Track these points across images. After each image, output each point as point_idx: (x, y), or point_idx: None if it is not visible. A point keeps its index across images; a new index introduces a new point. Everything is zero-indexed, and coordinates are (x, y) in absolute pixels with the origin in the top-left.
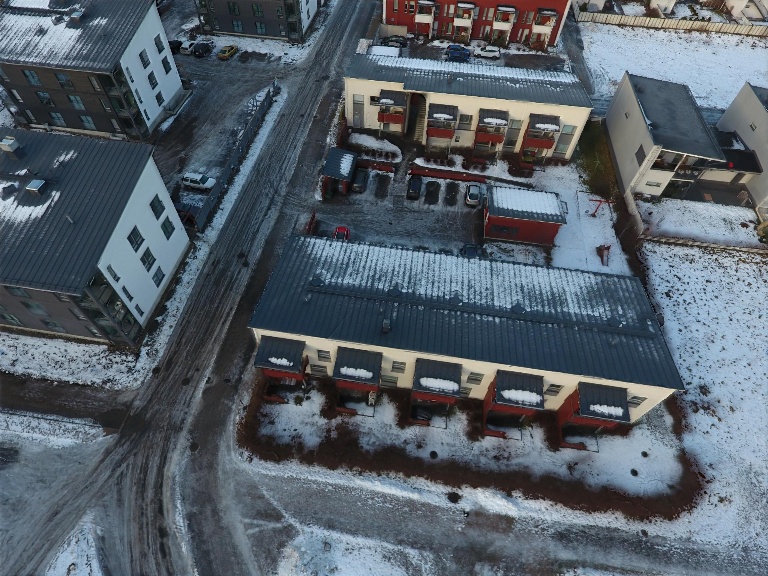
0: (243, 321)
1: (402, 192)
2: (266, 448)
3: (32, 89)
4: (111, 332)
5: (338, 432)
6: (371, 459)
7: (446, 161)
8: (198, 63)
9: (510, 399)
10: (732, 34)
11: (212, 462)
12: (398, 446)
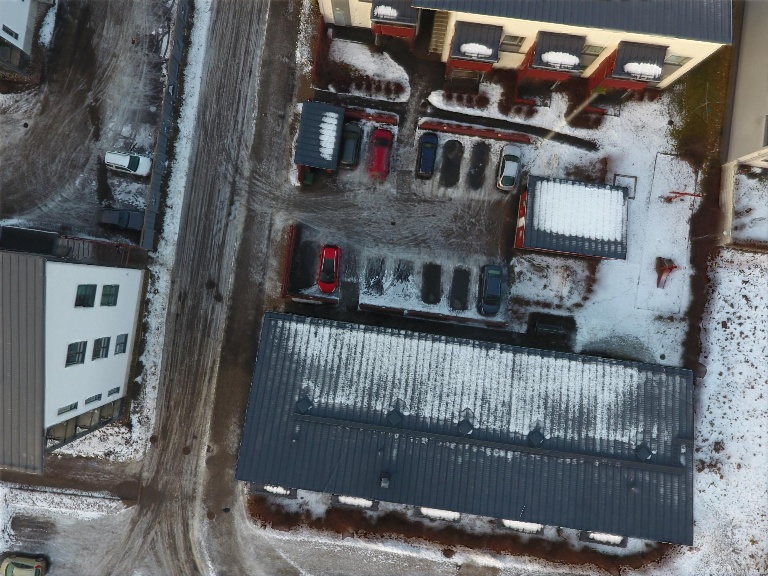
0: (230, 379)
1: (409, 164)
2: (277, 517)
3: None
4: None
5: None
6: (375, 524)
7: (475, 98)
8: None
9: (511, 528)
10: None
11: (230, 529)
12: (400, 511)
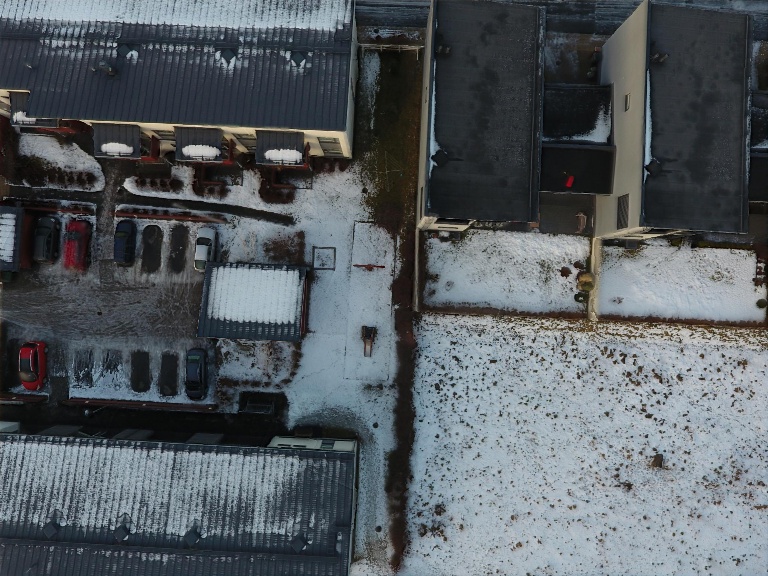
0: None
1: (110, 253)
2: None
3: None
4: None
5: None
6: None
7: (168, 182)
8: None
9: None
10: None
11: None
12: None
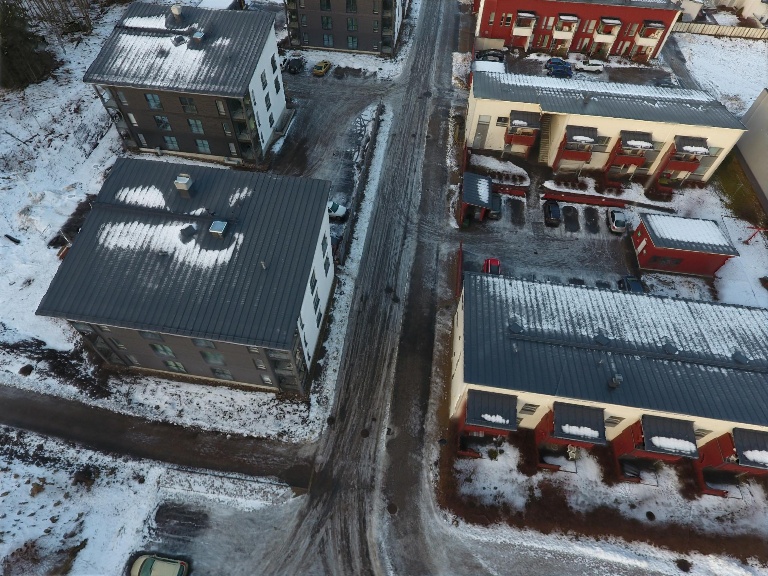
0: (409, 364)
1: (539, 218)
2: (471, 510)
3: (151, 113)
4: (281, 379)
5: (542, 490)
6: (585, 521)
7: (577, 184)
8: (294, 80)
9: (756, 461)
10: None
11: (416, 526)
12: (610, 506)
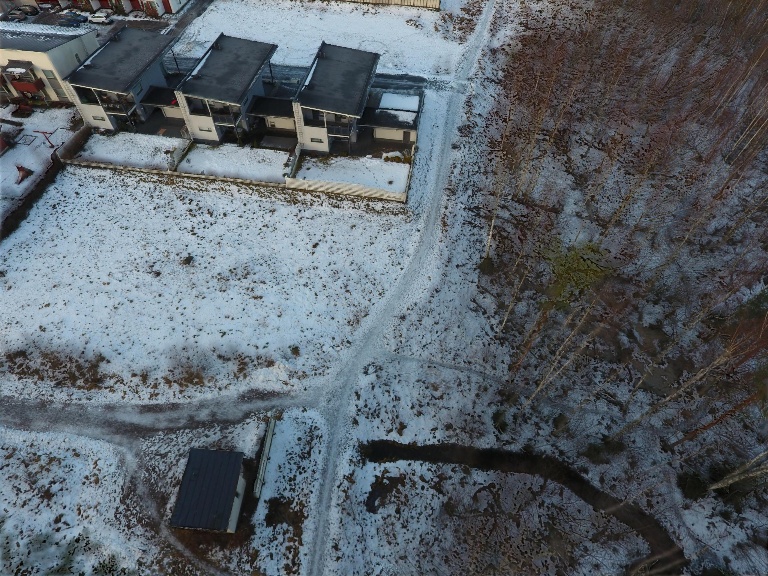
0: None
1: None
2: None
3: None
4: None
5: None
6: None
7: None
8: None
9: None
10: (350, 2)
11: None
12: None
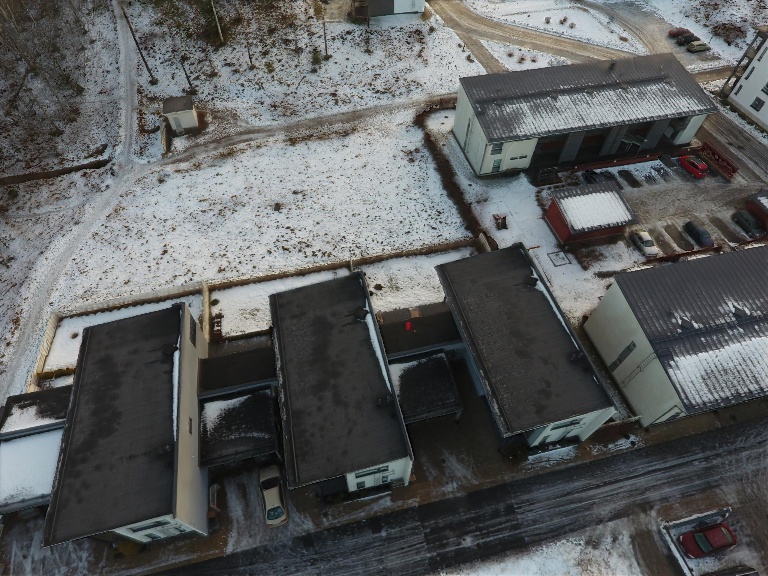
0: None
1: None
2: None
3: None
4: None
5: None
6: None
7: None
8: None
9: None
10: None
11: None
12: None
